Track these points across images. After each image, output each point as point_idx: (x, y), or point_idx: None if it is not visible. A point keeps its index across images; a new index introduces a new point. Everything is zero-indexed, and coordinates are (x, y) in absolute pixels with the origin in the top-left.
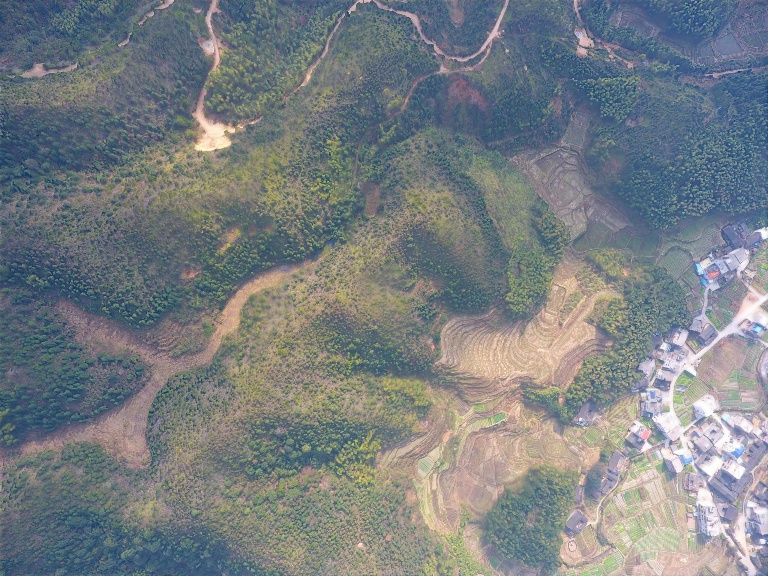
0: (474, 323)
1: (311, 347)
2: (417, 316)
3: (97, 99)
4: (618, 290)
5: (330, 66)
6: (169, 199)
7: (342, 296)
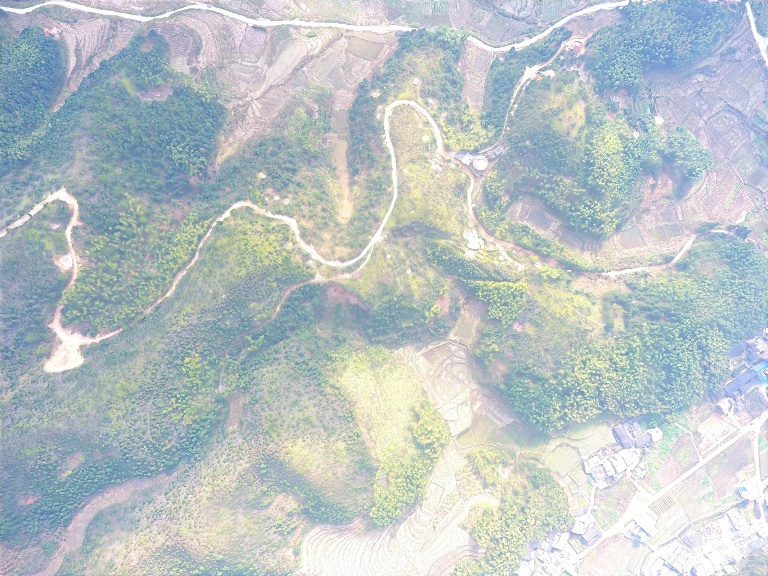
0: (339, 531)
1: (151, 575)
2: (273, 533)
3: None
4: (495, 496)
5: (195, 280)
6: (1, 437)
7: (184, 529)
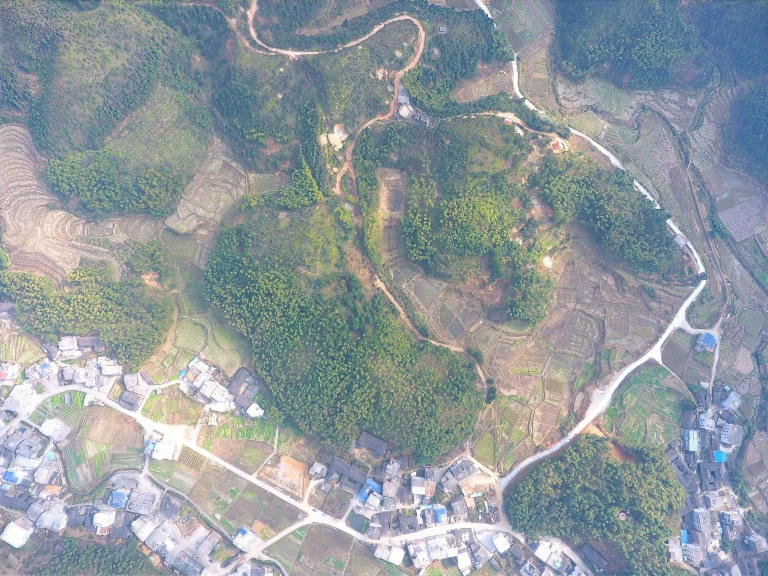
0: (31, 151)
1: None
2: (2, 87)
3: None
4: (122, 276)
5: None
6: None
7: None
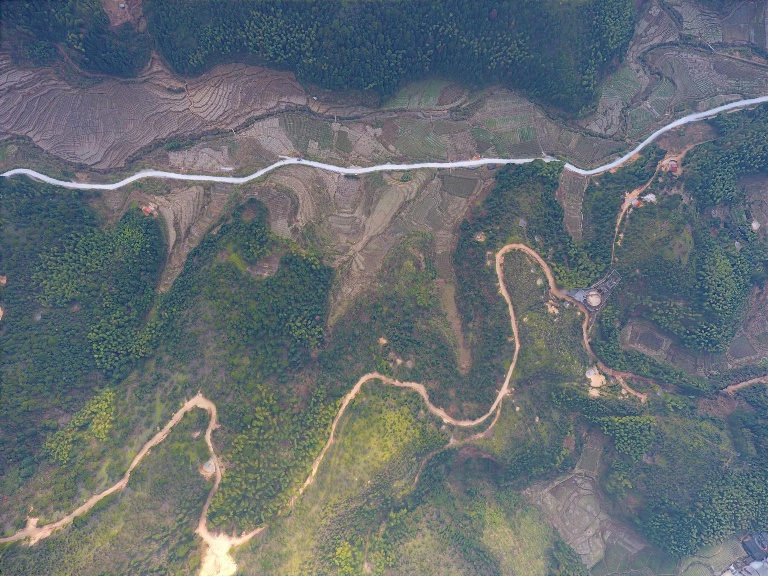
0: None
1: None
2: None
3: (95, 568)
4: None
5: (336, 467)
6: None
7: None
